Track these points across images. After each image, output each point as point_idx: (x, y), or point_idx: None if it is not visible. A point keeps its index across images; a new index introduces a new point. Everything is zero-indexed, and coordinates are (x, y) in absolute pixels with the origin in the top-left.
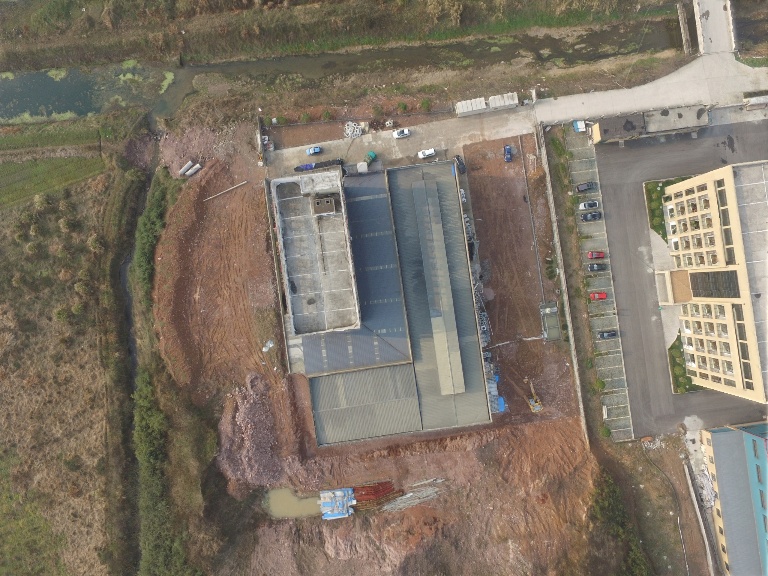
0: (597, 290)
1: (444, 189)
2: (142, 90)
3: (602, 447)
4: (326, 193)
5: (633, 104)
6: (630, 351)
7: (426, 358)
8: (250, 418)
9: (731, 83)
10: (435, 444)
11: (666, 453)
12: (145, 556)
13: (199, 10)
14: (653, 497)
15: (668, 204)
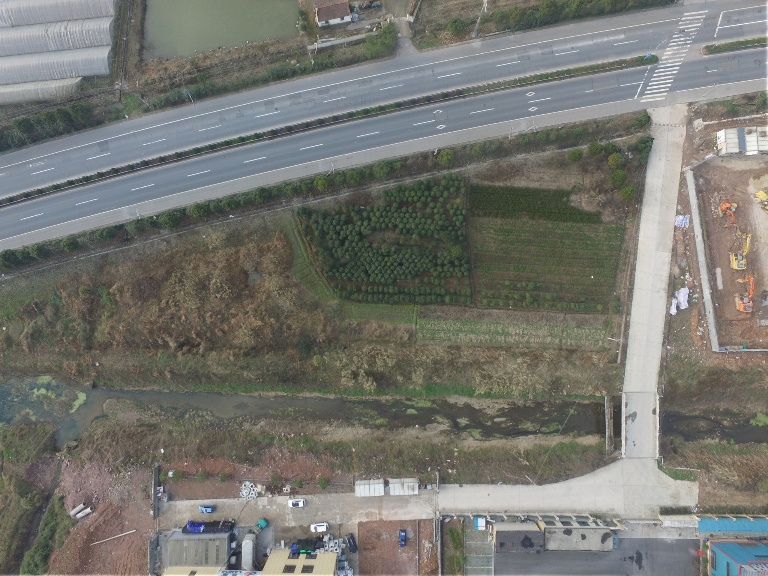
0: None
1: None
2: (53, 407)
3: None
4: None
5: (541, 502)
6: None
7: None
8: None
9: (649, 494)
10: None
11: None
12: None
13: (116, 343)
14: None
15: None
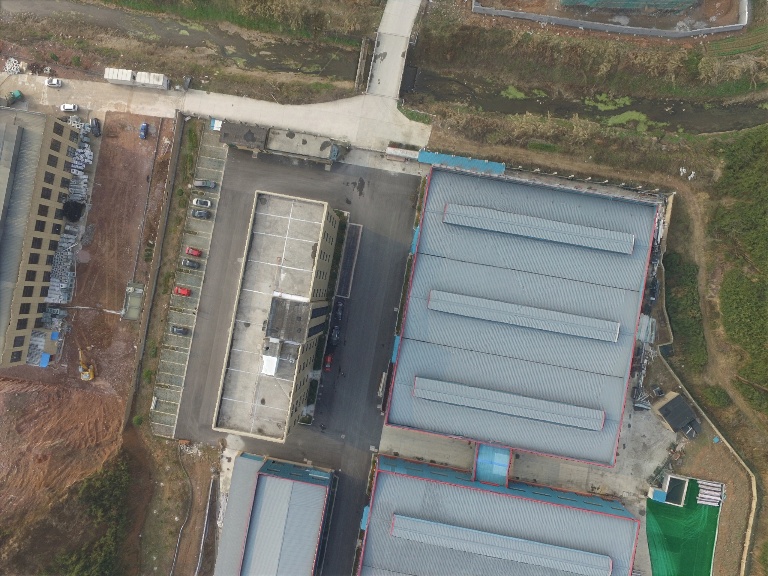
0: (185, 286)
1: (31, 139)
2: None
3: (141, 435)
4: None
5: (280, 120)
6: (197, 353)
7: None
8: None
9: (382, 128)
10: None
11: (199, 462)
12: None
13: None
14: (165, 498)
15: None
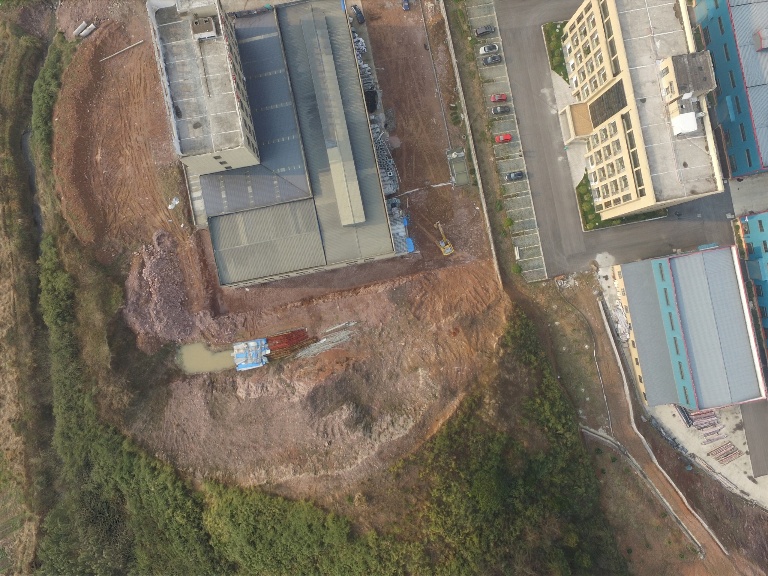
0: (502, 133)
1: (335, 24)
2: None
3: (516, 288)
4: (205, 15)
5: None
6: (538, 192)
7: (326, 192)
8: (157, 272)
9: None
10: (348, 292)
11: (580, 291)
12: (59, 421)
13: None
14: (568, 332)
15: (566, 42)
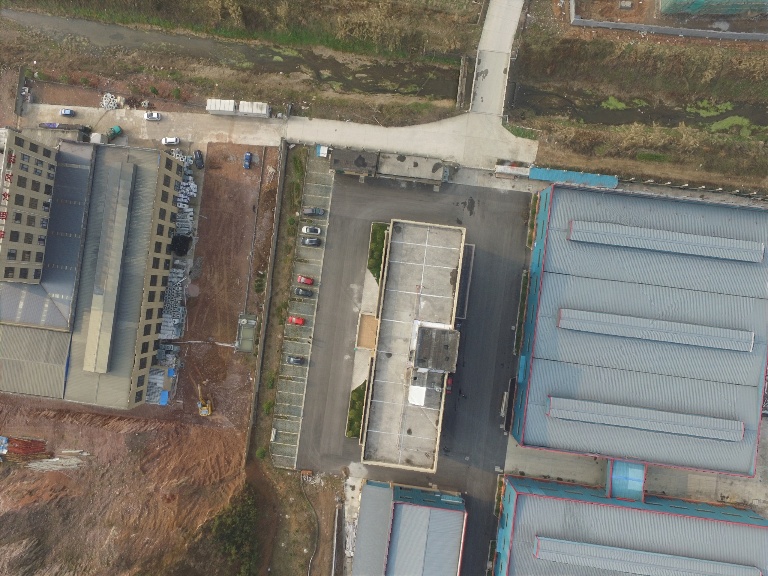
0: (299, 315)
1: (145, 176)
2: None
3: (262, 468)
4: (1, 148)
5: (385, 143)
6: (315, 382)
7: (85, 332)
8: None
9: (489, 146)
10: (100, 419)
11: (323, 492)
12: None
13: None
14: (292, 530)
15: None
